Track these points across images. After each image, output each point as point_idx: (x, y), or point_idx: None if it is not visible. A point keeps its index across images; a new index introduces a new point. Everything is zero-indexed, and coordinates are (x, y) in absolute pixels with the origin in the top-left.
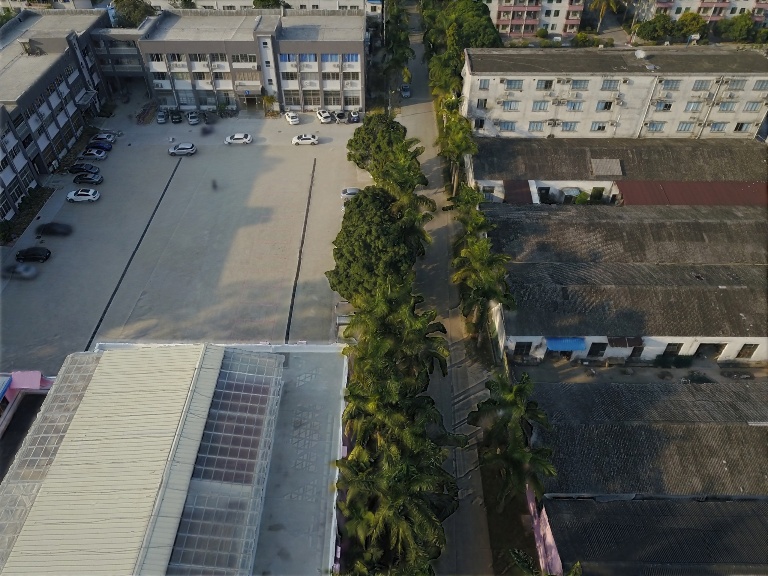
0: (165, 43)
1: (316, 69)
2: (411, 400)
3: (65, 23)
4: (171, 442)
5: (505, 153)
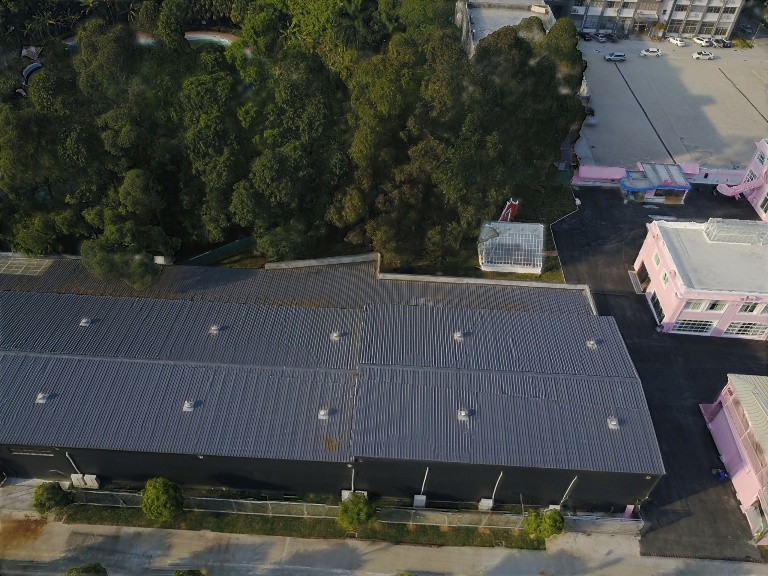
0: None
1: (705, 3)
2: None
3: None
4: None
5: None
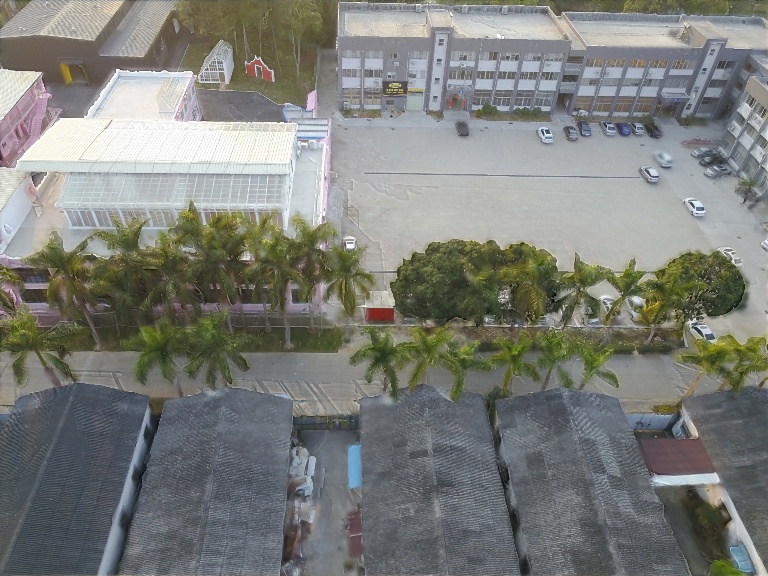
0: (765, 92)
1: None
2: (197, 246)
3: (762, 41)
4: (206, 161)
5: (762, 433)
